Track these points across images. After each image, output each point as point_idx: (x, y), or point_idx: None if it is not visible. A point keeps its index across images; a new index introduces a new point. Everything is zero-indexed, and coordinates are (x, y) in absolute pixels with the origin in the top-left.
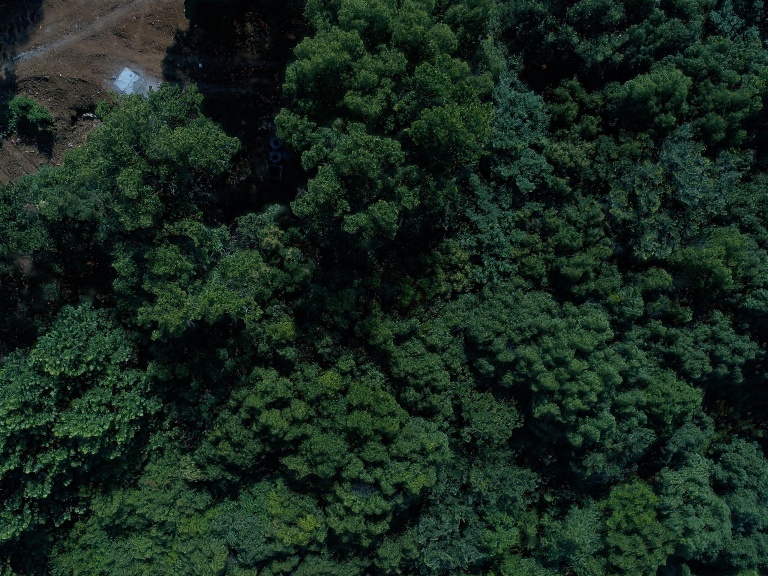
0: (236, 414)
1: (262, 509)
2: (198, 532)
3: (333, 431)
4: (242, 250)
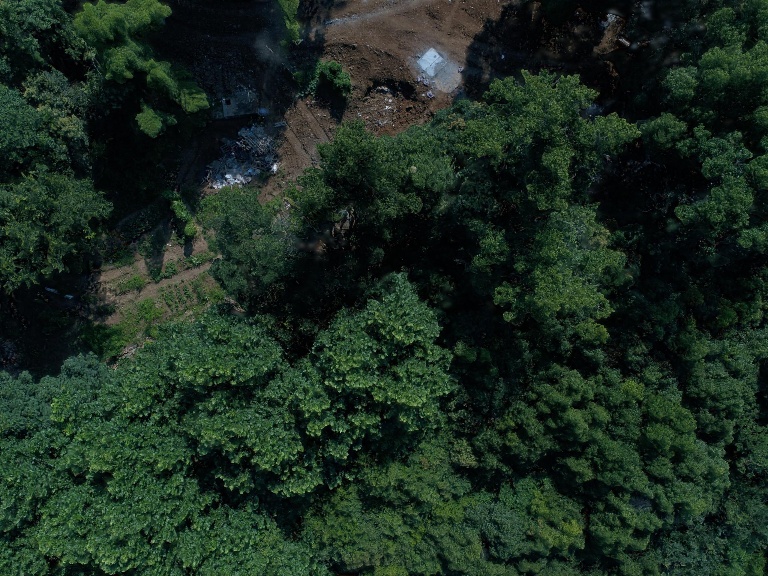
0: (530, 407)
1: (521, 506)
2: (449, 518)
3: (622, 440)
4: None
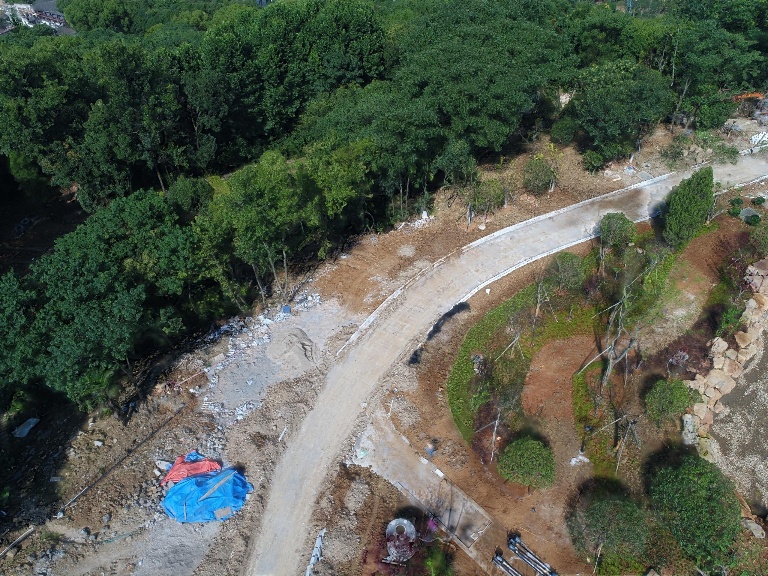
0: None
1: None
2: None
3: None
4: None
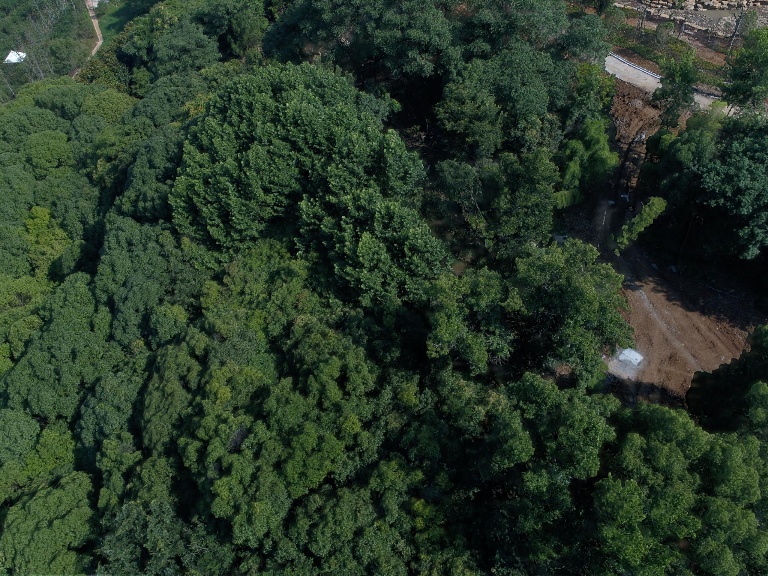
0: None
1: None
2: None
3: None
4: (483, 391)
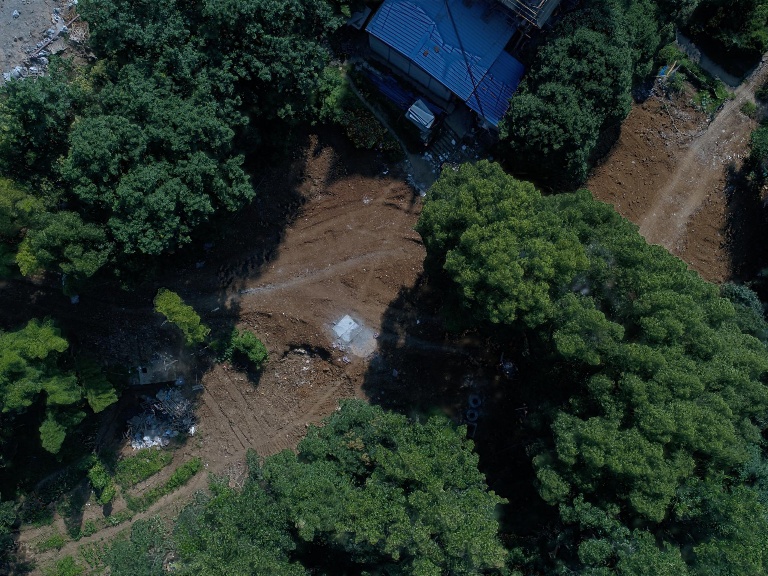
0: None
1: None
2: None
3: None
4: None
